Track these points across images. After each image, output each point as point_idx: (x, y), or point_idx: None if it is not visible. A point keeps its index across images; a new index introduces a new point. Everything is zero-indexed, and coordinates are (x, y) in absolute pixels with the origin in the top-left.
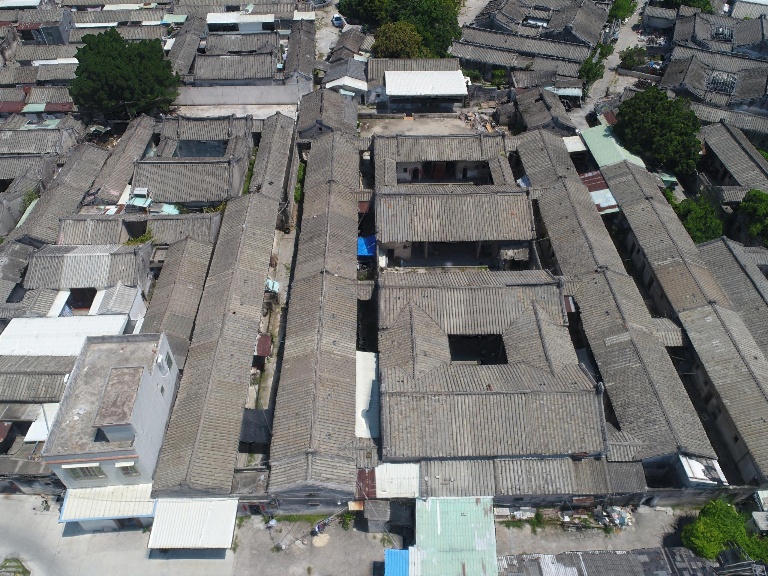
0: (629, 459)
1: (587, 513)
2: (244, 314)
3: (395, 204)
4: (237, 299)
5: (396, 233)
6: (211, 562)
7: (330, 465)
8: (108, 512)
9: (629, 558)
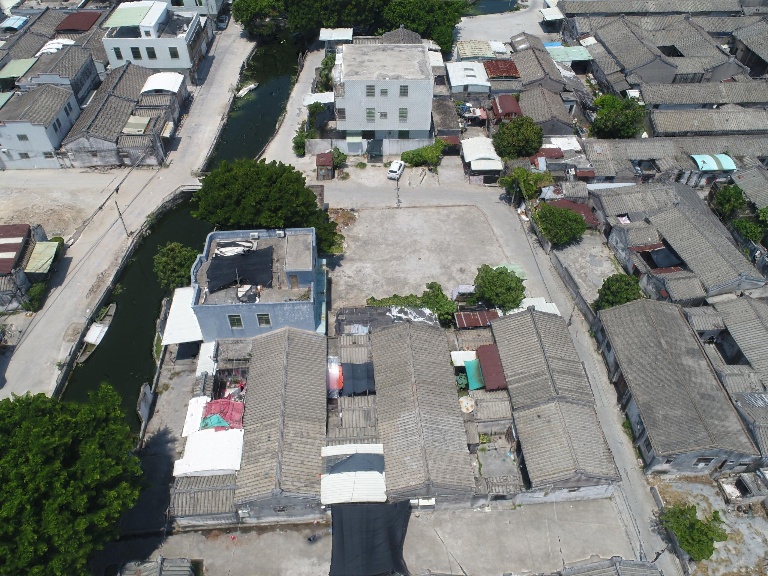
0: (630, 82)
1: (602, 95)
2: (649, 6)
3: (763, 26)
4: (656, 2)
5: (742, 35)
6: (542, 31)
7: (586, 24)
8: (548, 1)
9: (583, 89)
